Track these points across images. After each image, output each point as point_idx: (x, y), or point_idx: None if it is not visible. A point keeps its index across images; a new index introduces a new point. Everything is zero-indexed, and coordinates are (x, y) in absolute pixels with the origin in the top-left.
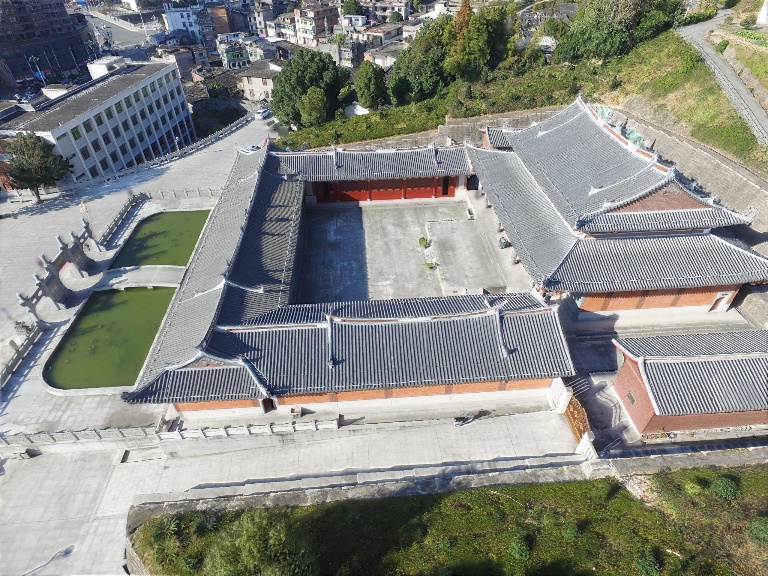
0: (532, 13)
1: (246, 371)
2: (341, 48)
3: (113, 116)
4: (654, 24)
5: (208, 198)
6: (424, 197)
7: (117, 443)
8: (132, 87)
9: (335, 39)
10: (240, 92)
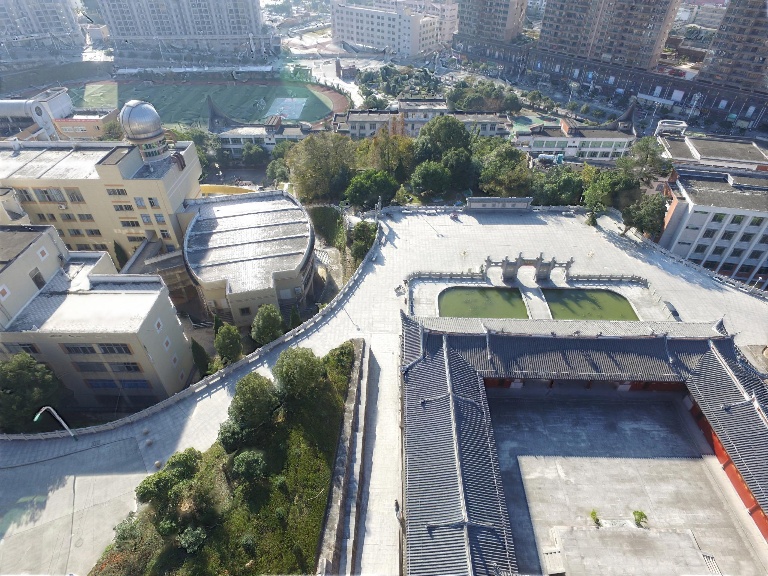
0: None
1: None
2: None
3: None
4: None
5: None
6: None
7: None
8: None
9: None
10: None
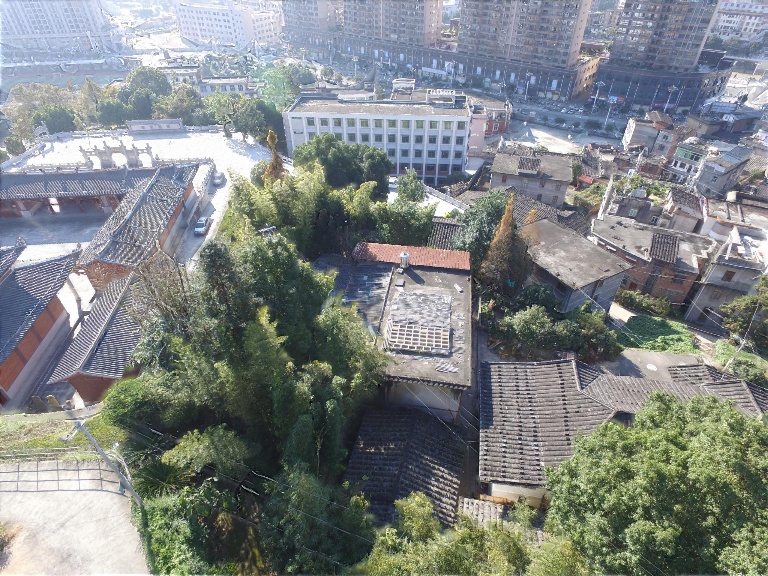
0: None
1: None
2: None
3: (355, 126)
4: None
5: None
6: None
7: None
8: (389, 115)
9: None
10: None
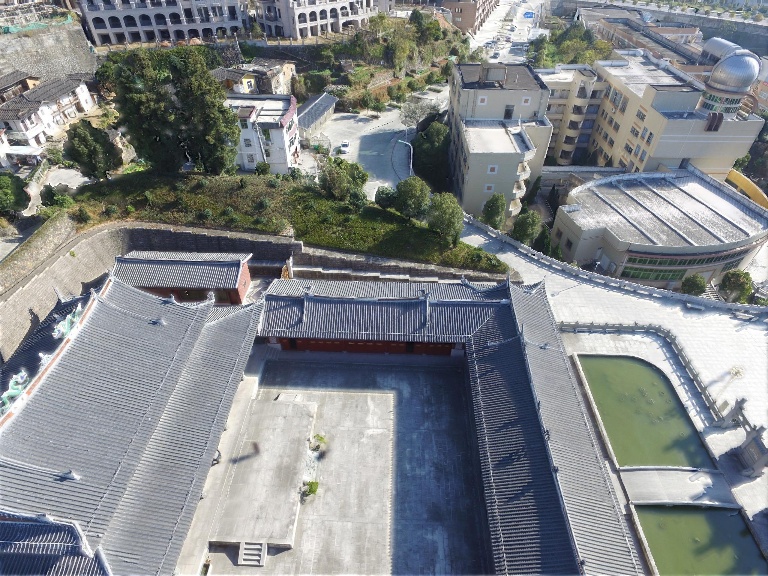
0: None
1: None
2: None
3: None
4: None
5: None
6: None
7: None
8: None
9: None
10: None
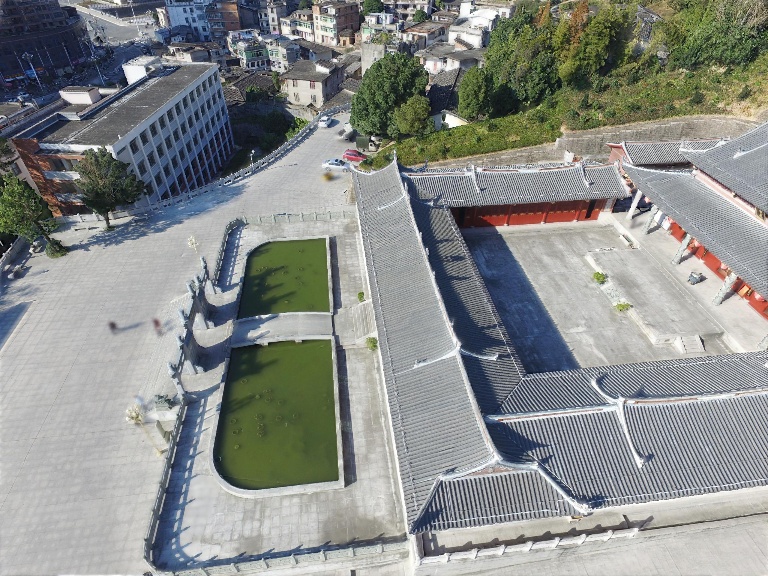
0: (558, 13)
1: (540, 477)
2: (387, 49)
3: (165, 125)
4: None
5: (313, 223)
6: (565, 221)
7: (342, 563)
8: (182, 92)
9: (380, 39)
10: (282, 96)
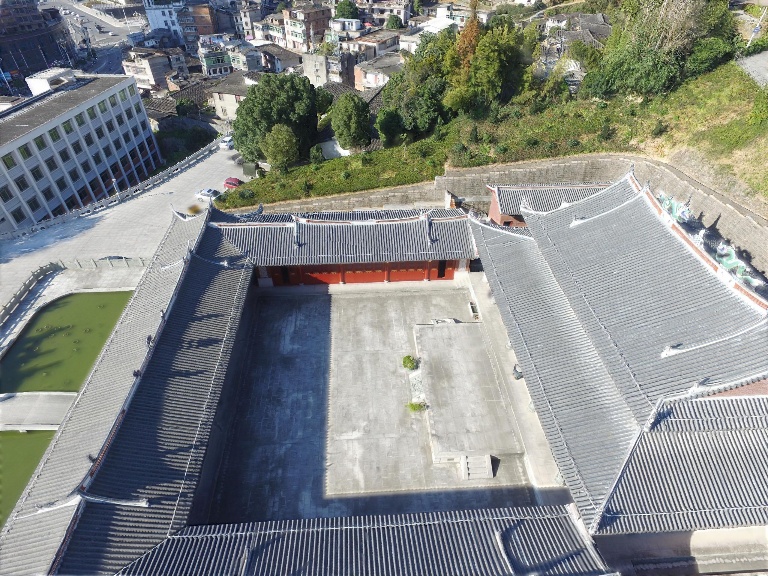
0: (543, 19)
1: None
2: (328, 60)
3: (46, 145)
4: (712, 55)
5: (138, 270)
6: (414, 280)
7: None
8: (73, 109)
9: (322, 49)
10: (211, 109)
